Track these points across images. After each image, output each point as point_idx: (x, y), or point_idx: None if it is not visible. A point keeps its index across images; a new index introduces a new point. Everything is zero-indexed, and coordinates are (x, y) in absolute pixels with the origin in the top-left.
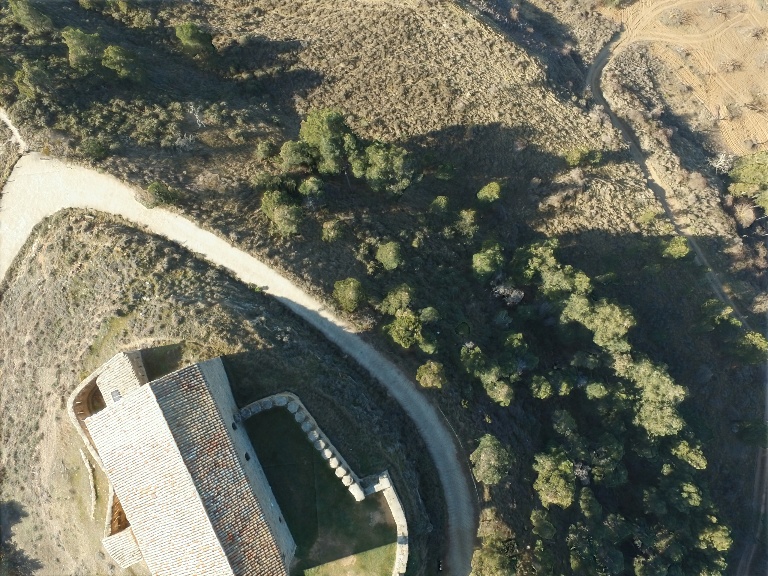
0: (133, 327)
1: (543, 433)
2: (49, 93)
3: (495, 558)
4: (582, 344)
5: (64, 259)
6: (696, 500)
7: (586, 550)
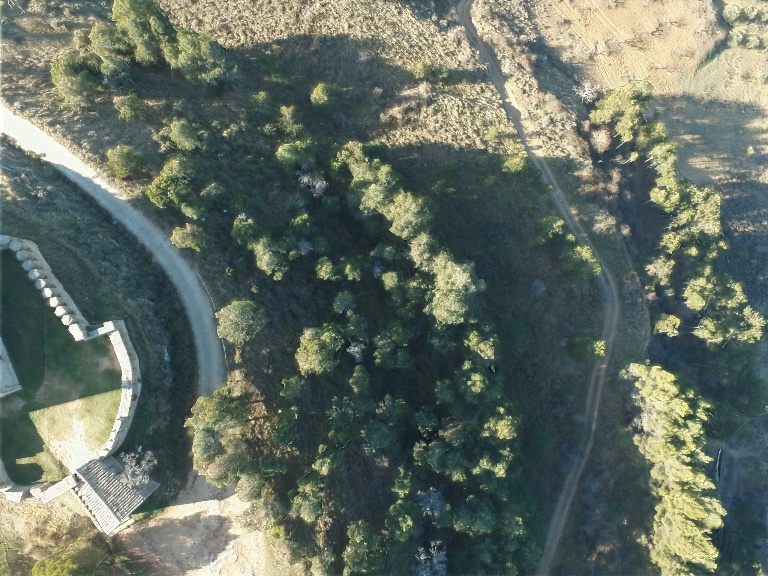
0: None
1: (334, 319)
2: None
3: (212, 402)
4: (393, 241)
5: None
6: (478, 387)
7: (334, 414)
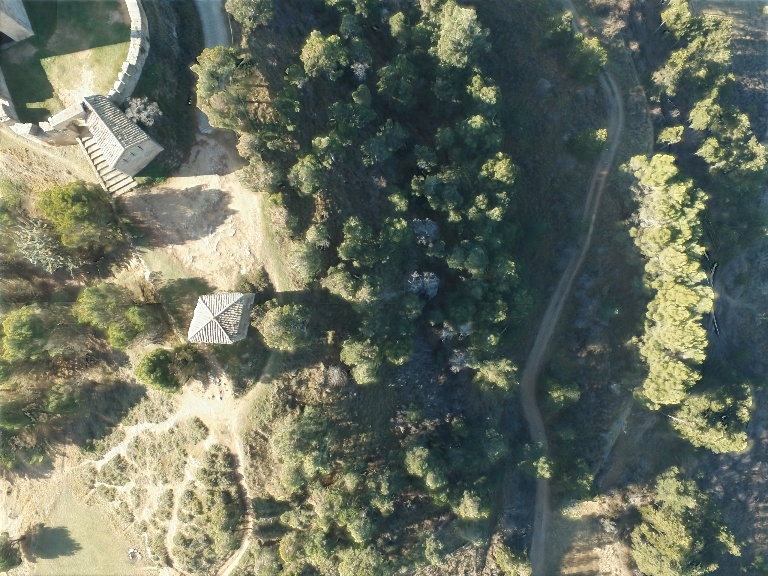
0: None
1: None
2: None
3: None
4: None
5: None
6: (478, 122)
7: (335, 103)
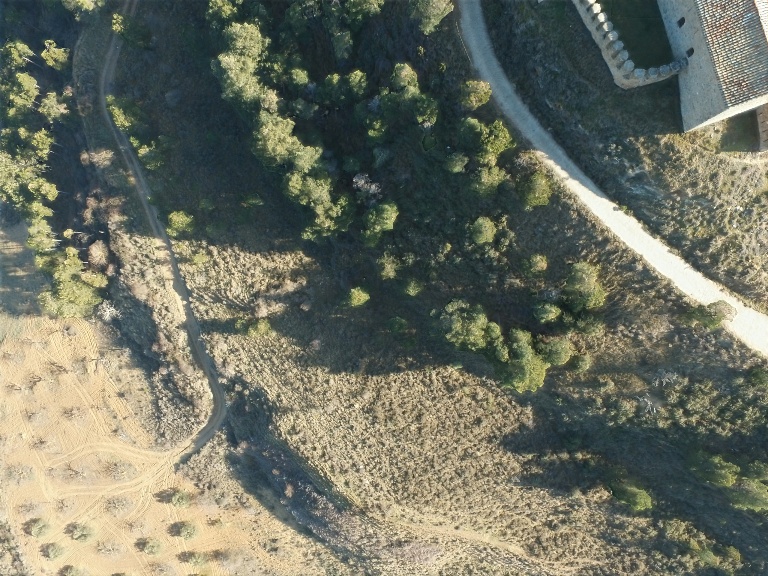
0: (760, 179)
1: (358, 43)
2: None
3: None
4: None
5: None
6: None
7: None
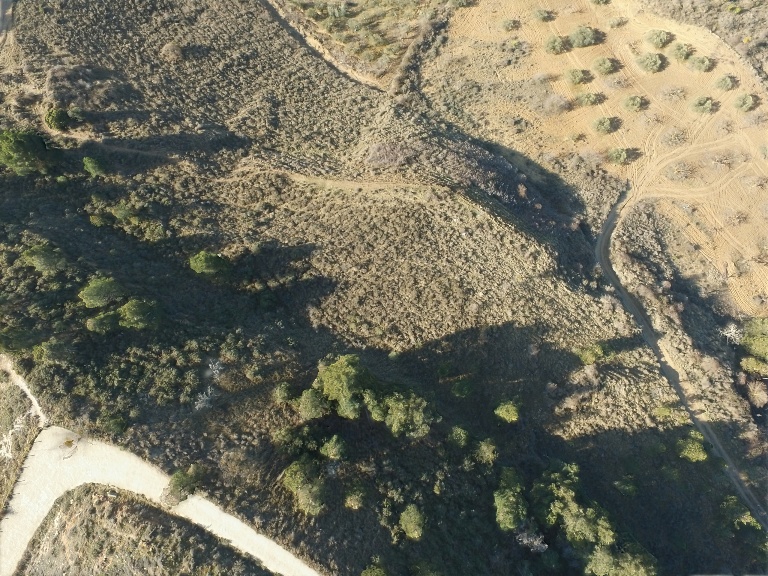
0: None
1: None
2: (67, 360)
3: None
4: None
5: (88, 548)
6: None
7: None
